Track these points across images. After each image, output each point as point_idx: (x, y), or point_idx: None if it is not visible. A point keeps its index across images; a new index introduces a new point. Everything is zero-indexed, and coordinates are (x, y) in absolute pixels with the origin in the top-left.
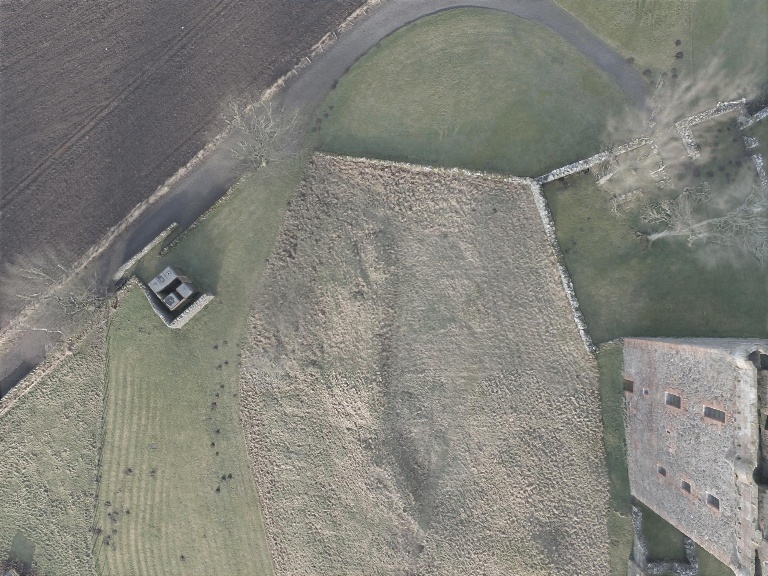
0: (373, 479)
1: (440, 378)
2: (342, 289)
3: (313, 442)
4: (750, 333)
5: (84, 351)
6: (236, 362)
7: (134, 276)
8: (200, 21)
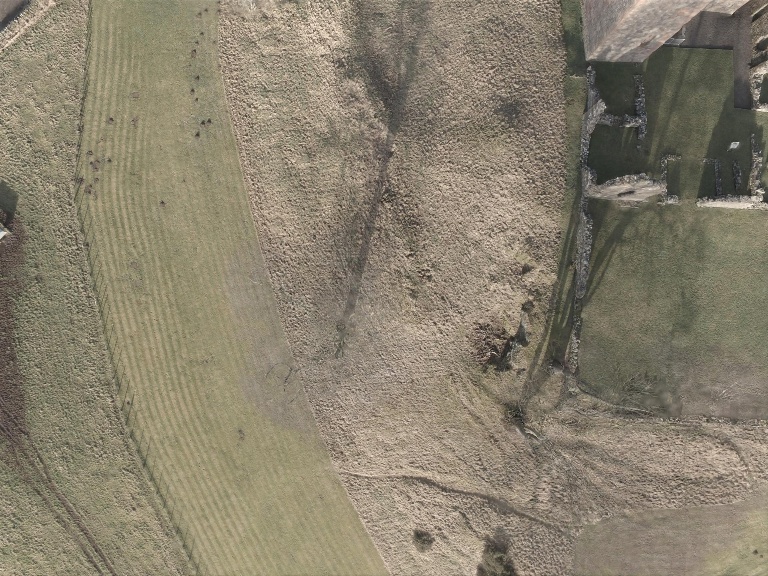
0: (346, 95)
1: None
2: None
3: (289, 78)
4: None
5: (67, 2)
6: (215, 10)
7: None
8: None
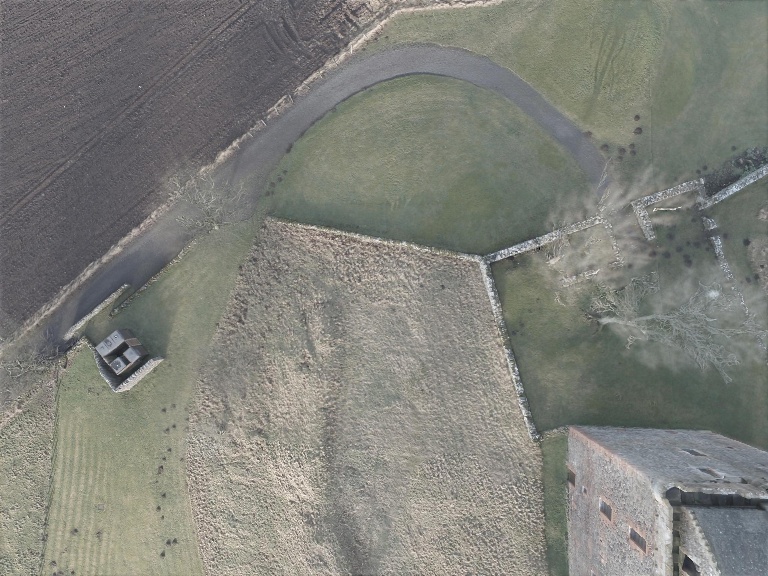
0: (314, 555)
1: (383, 456)
2: (289, 359)
3: (257, 512)
4: (702, 425)
5: (34, 409)
6: (184, 426)
7: (84, 337)
8: (157, 81)
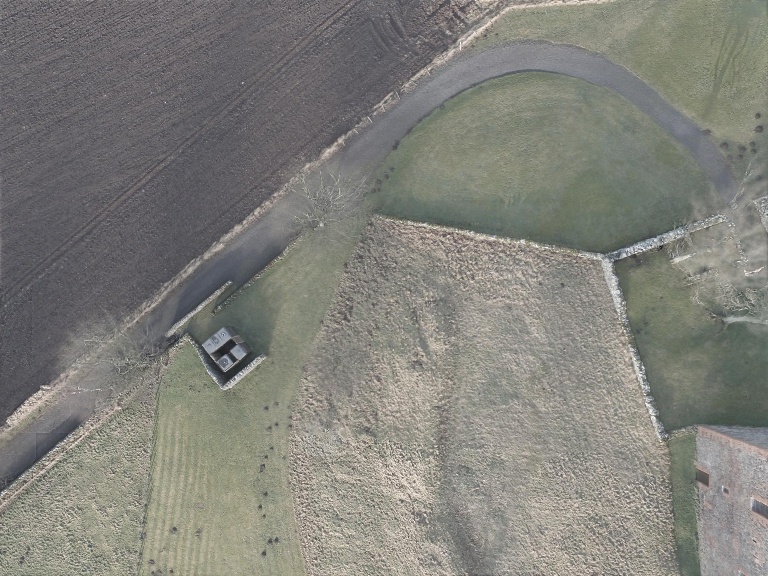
0: (427, 555)
1: (500, 455)
2: (400, 357)
3: (364, 511)
4: None
5: (133, 406)
6: (286, 424)
7: (187, 334)
8: (260, 77)
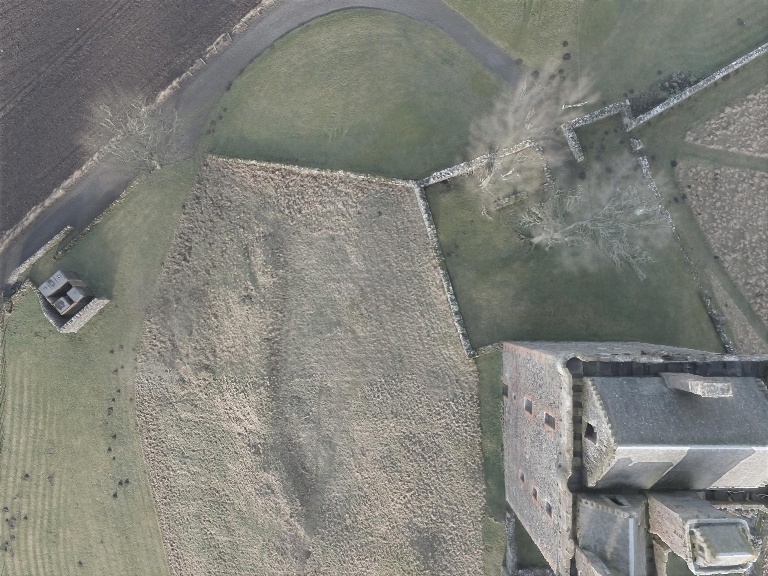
0: (262, 484)
1: (326, 383)
2: (232, 293)
3: (207, 447)
4: (631, 337)
5: None
6: (132, 366)
7: (28, 280)
8: (96, 22)
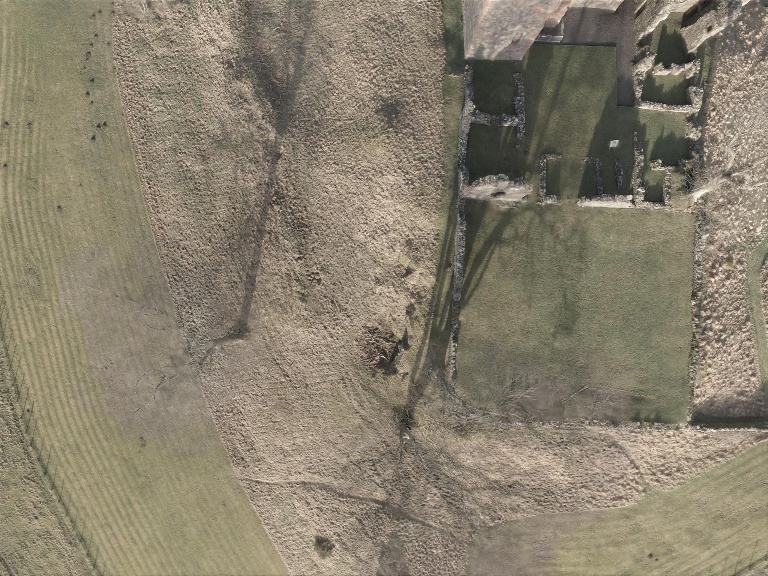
0: (235, 97)
1: None
2: None
3: (182, 79)
4: None
5: None
6: (109, 11)
7: None
8: None
